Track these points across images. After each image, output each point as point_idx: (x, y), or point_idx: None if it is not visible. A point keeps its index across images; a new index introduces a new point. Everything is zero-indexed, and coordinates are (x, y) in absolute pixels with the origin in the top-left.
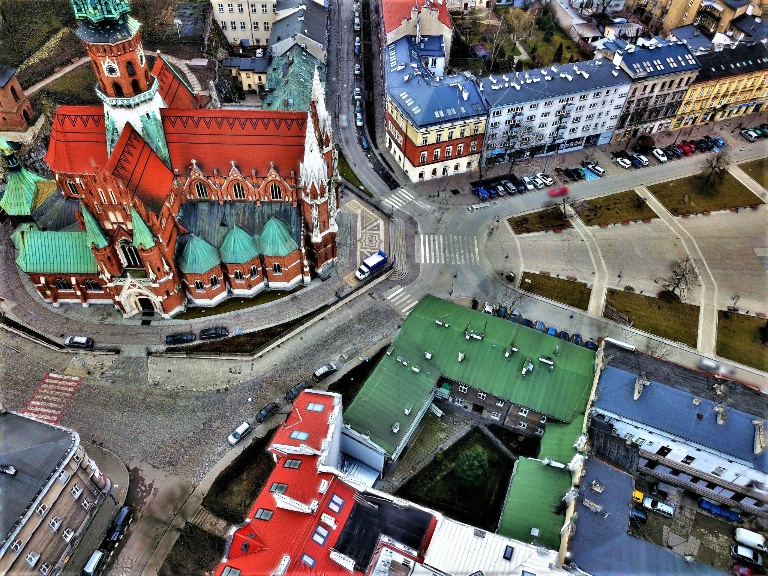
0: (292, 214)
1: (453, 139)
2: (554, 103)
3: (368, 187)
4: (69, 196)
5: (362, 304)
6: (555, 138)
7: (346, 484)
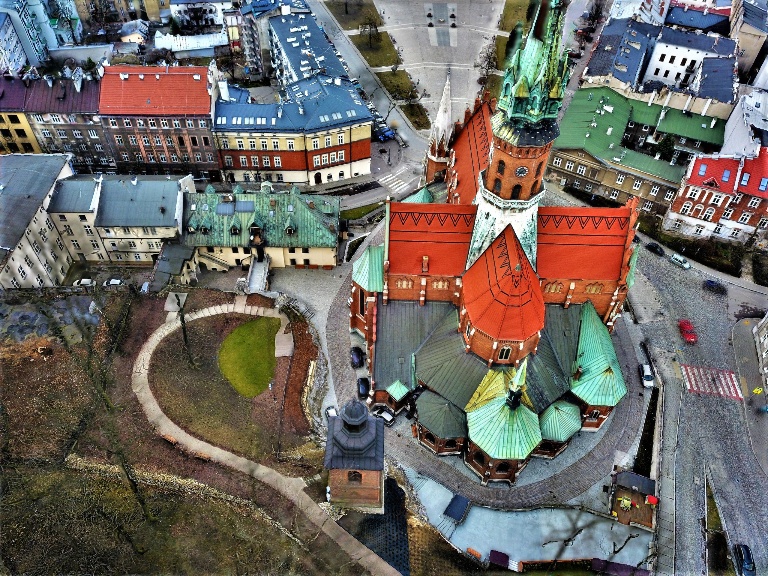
0: None
1: None
2: None
3: (379, 200)
4: None
5: None
6: None
7: None
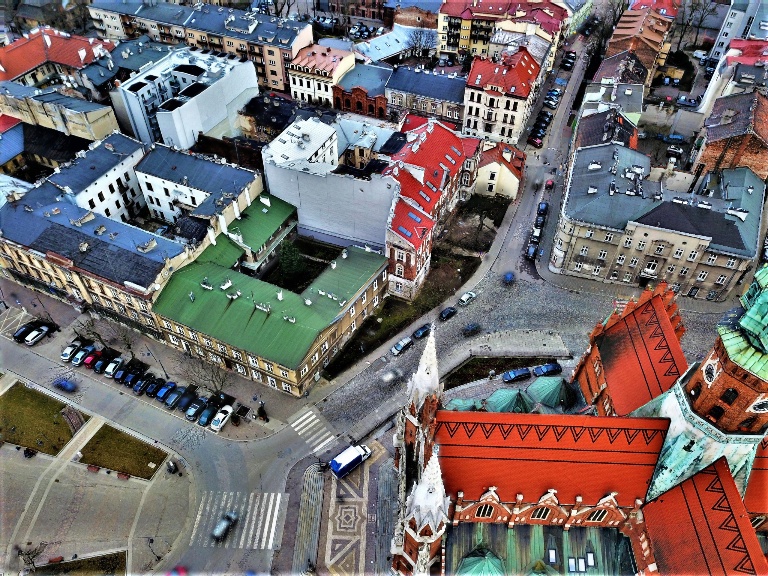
0: None
1: None
2: None
3: None
4: None
5: (364, 427)
6: None
7: None
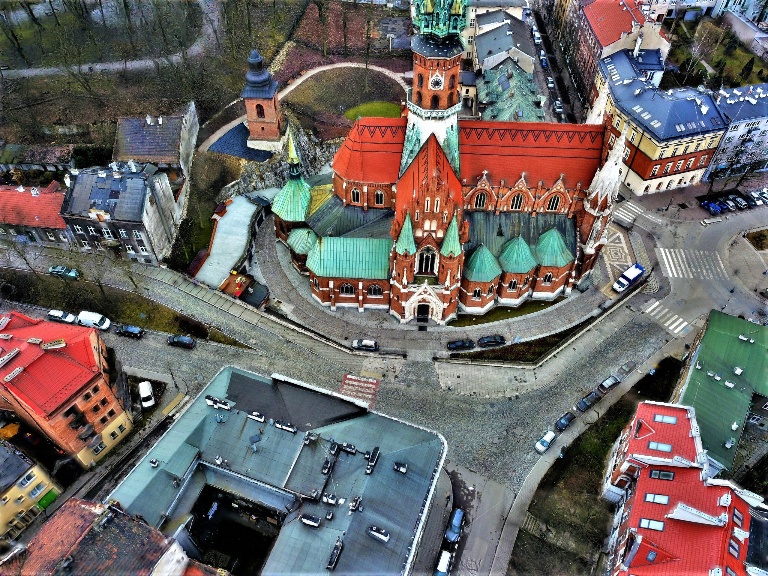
0: (566, 225)
1: (687, 153)
2: None
3: None
4: (348, 204)
5: (623, 317)
6: None
7: (741, 498)
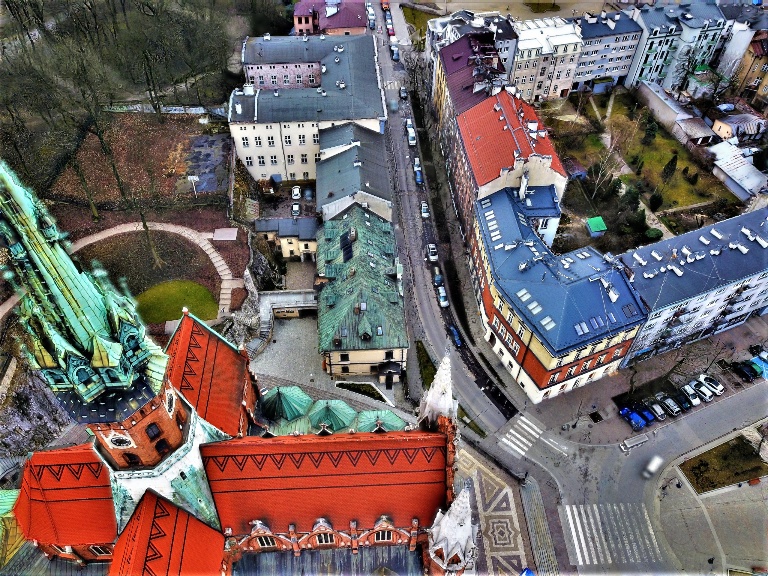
0: (408, 563)
1: (595, 352)
2: (728, 289)
3: (475, 418)
4: (56, 554)
5: None
6: (716, 321)
7: None
